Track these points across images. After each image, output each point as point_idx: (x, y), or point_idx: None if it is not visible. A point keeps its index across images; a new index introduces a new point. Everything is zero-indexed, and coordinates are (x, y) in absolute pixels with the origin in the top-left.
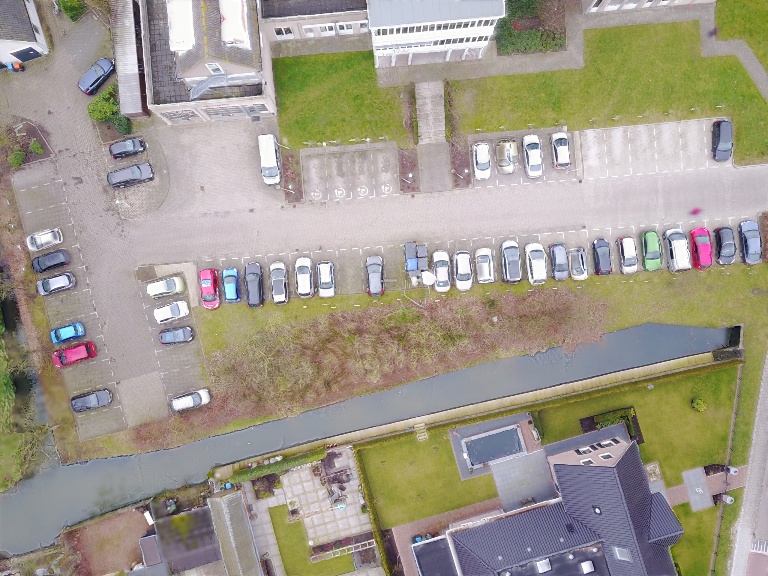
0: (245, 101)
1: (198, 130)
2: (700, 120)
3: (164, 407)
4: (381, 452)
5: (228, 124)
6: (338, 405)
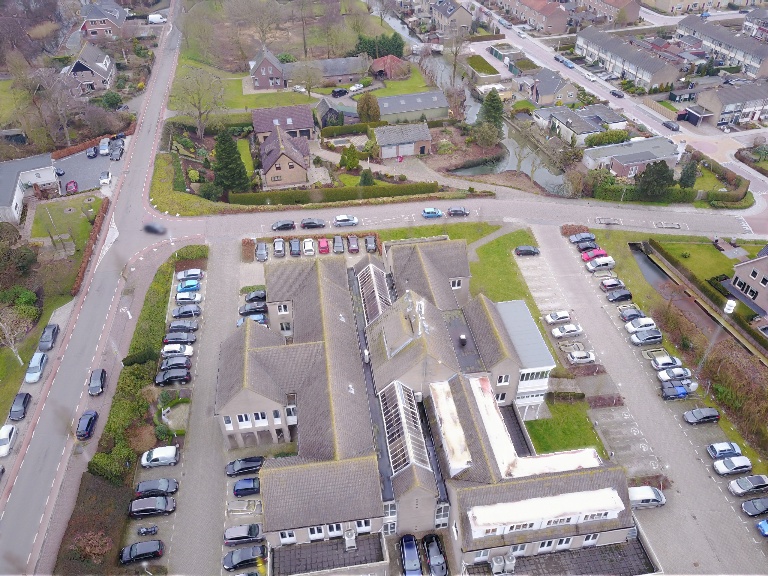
0: None
1: None
2: (516, 261)
3: None
4: None
5: None
6: None
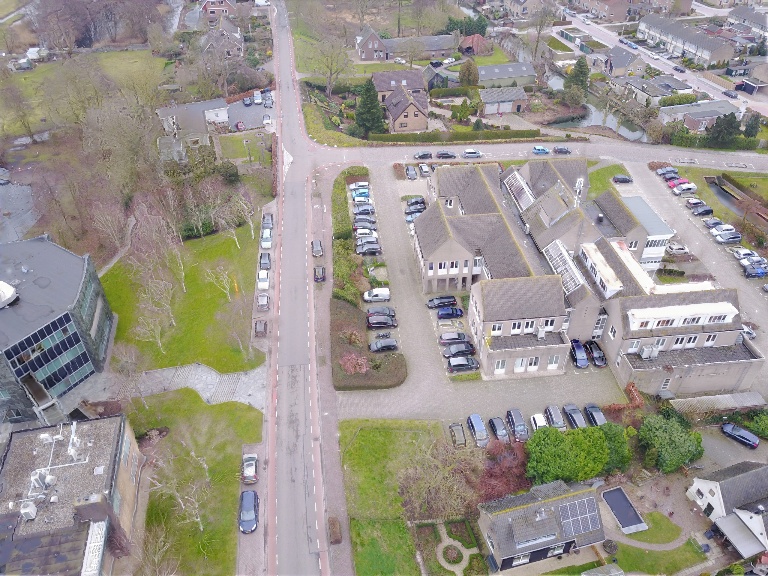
0: None
1: None
2: (615, 186)
3: None
4: None
5: None
6: None
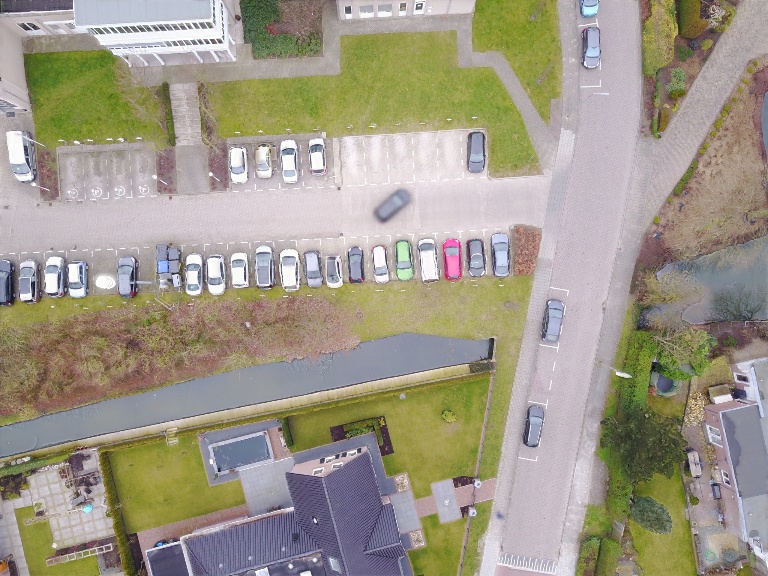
0: None
1: None
2: (457, 131)
3: None
4: (129, 455)
5: None
6: (92, 407)
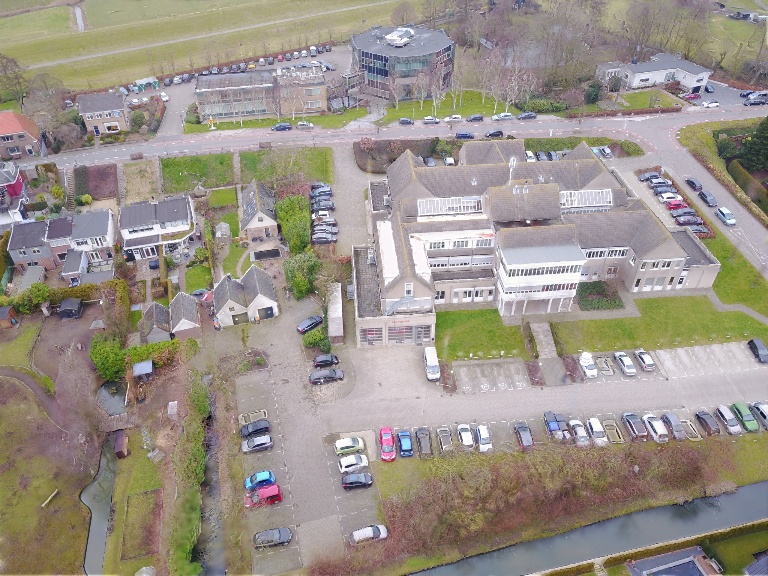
0: (421, 318)
1: (378, 351)
2: (737, 343)
3: (340, 547)
4: None
5: (400, 348)
6: (509, 550)
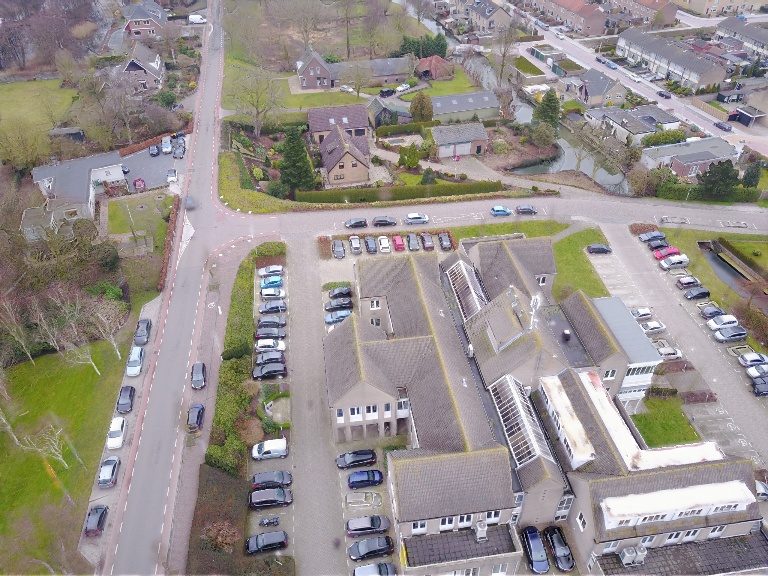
0: None
1: None
2: (589, 259)
3: None
4: None
5: None
6: None
